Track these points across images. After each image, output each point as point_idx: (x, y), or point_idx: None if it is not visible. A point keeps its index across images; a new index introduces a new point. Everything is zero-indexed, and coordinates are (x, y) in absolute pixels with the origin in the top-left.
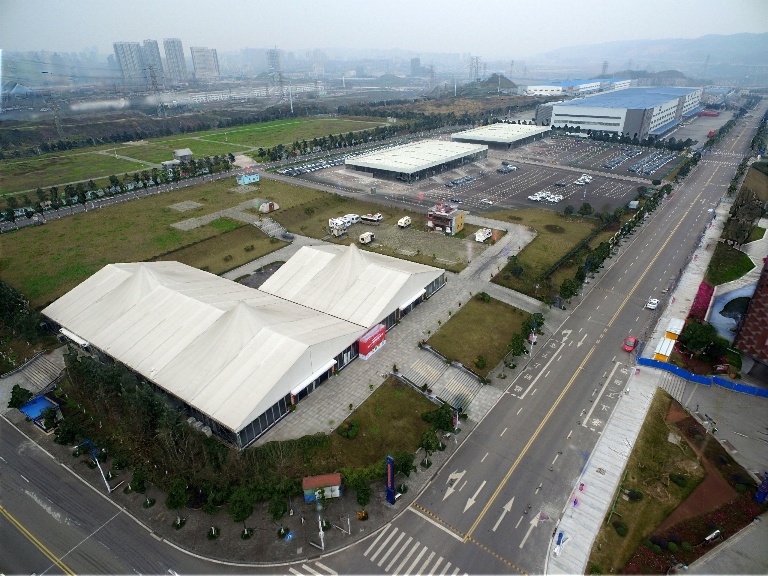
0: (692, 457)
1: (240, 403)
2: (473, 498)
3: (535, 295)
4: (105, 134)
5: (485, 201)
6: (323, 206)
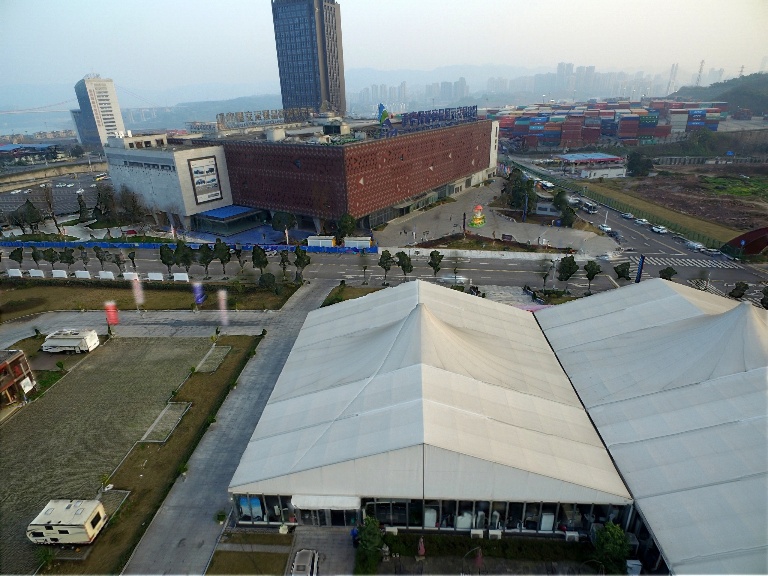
0: (455, 241)
1: (763, 314)
2: (582, 278)
3: None
4: None
5: None
6: None
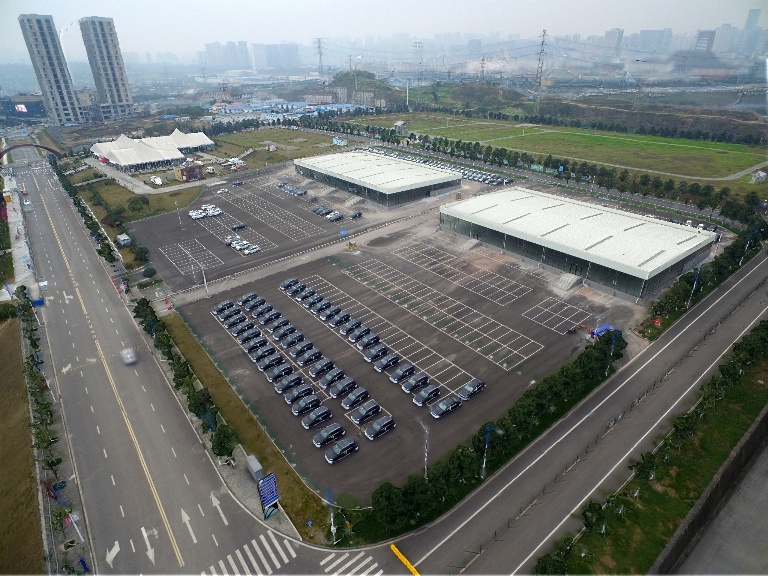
0: None
1: None
2: None
3: None
4: None
5: None
6: (277, 160)
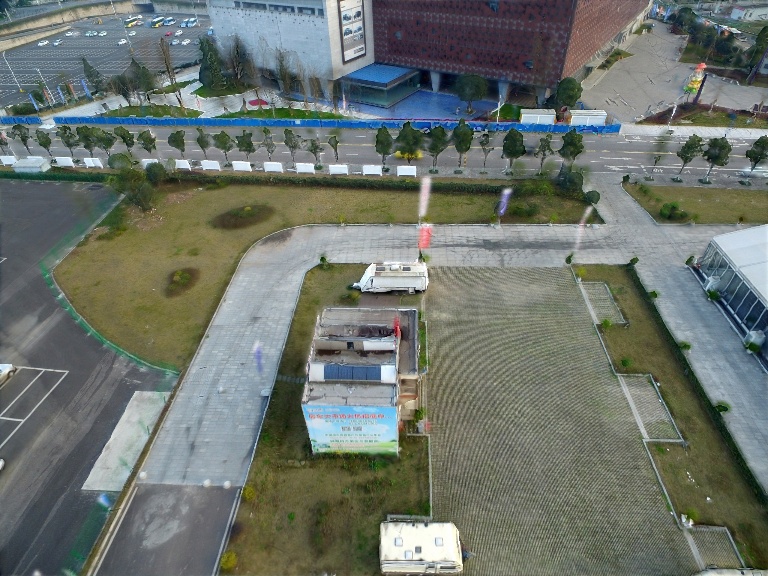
0: (698, 115)
1: None
2: None
3: None
4: None
5: None
6: None
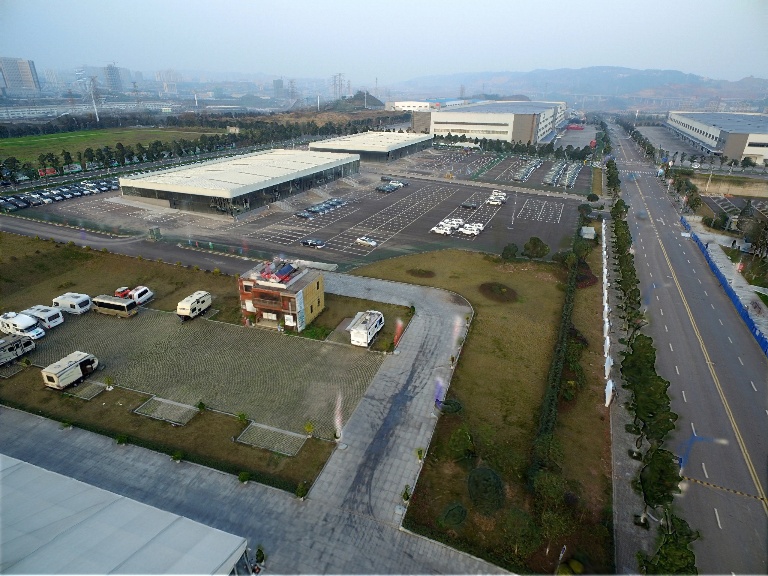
0: None
1: None
2: None
3: (553, 575)
4: None
5: (363, 241)
6: (29, 273)
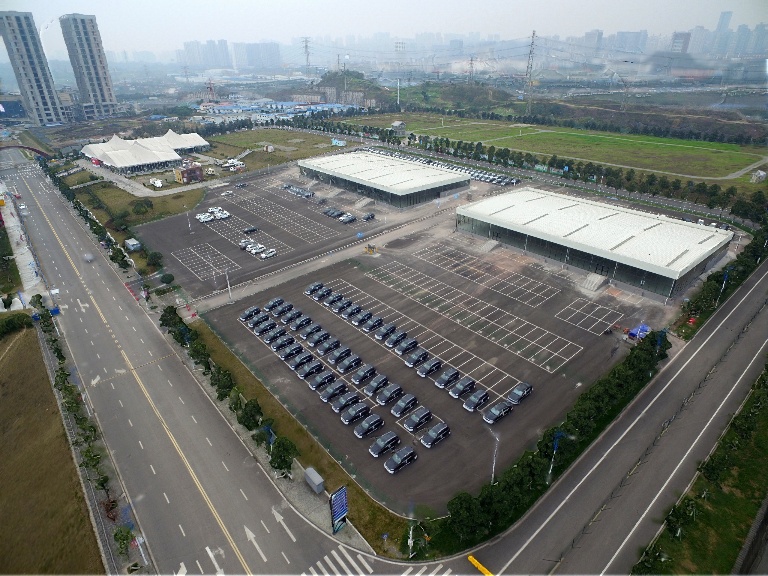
0: None
1: None
2: None
3: None
4: (631, 124)
5: None
6: None
